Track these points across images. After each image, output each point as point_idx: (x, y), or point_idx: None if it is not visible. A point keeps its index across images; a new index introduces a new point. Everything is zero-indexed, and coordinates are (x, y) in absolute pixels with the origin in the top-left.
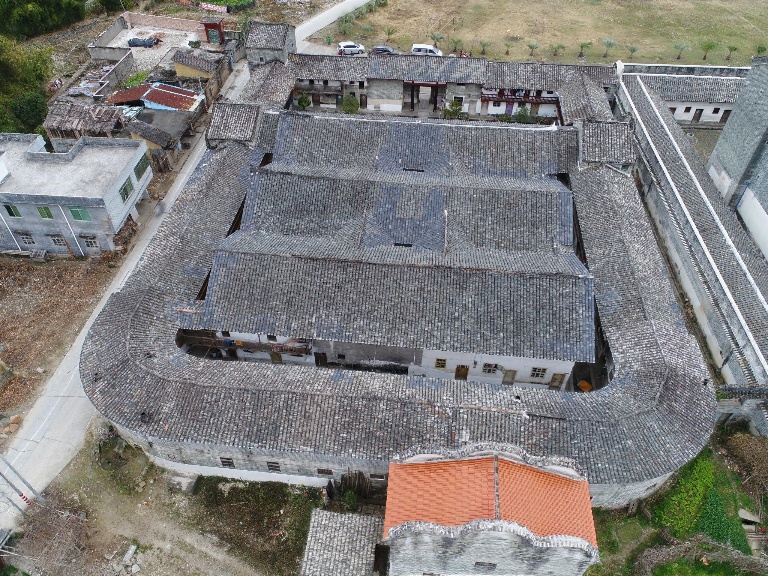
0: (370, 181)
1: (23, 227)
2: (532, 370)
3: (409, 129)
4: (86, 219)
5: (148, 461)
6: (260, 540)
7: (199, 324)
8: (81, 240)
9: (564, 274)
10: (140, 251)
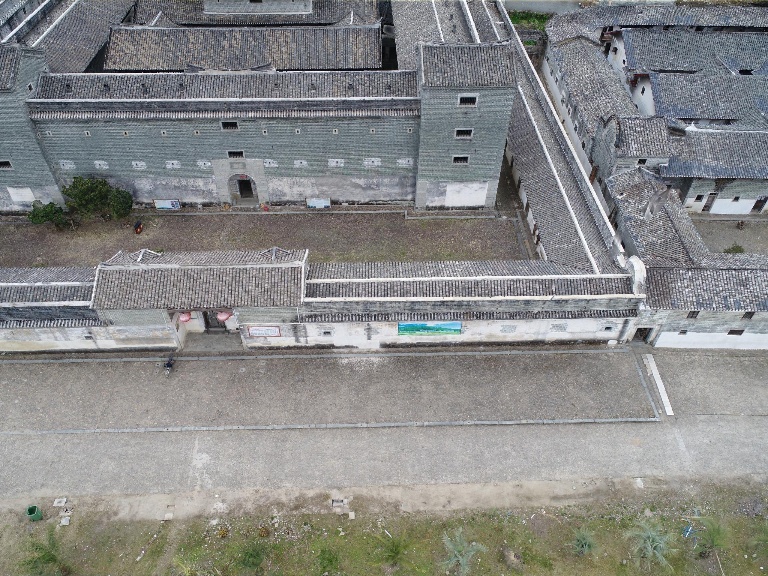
0: None
1: None
2: None
3: None
4: None
5: None
6: None
7: None
8: None
9: (640, 28)
10: None
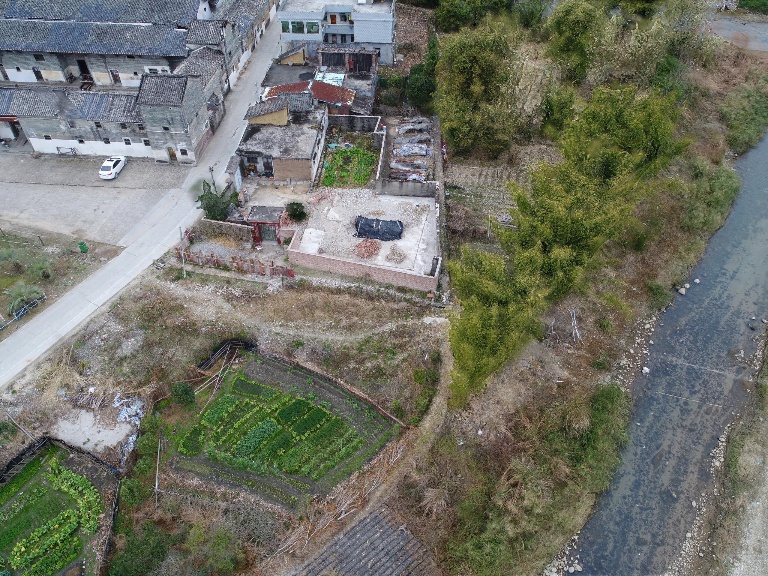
0: None
1: None
2: None
3: None
4: None
5: None
6: None
7: None
8: None
9: None
10: None
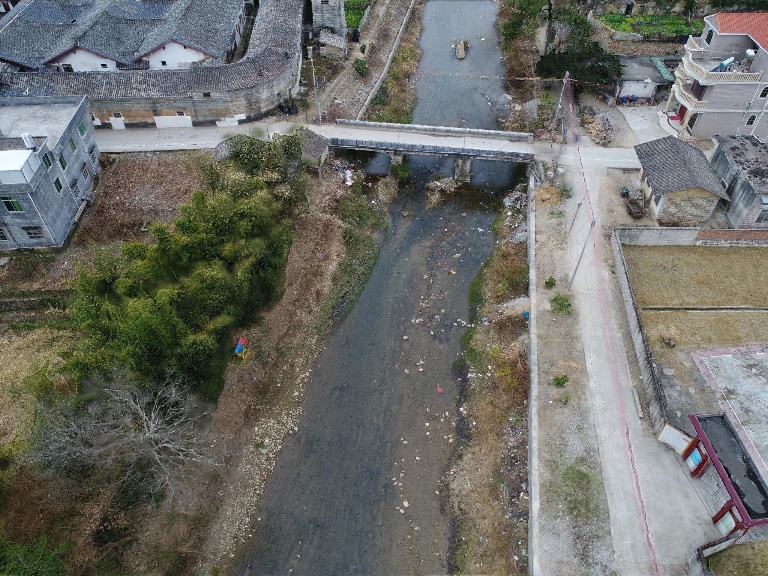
0: (104, 12)
1: (71, 177)
2: (242, 11)
3: (31, 11)
4: (84, 132)
5: (293, 98)
6: (327, 74)
7: (219, 60)
8: (90, 159)
9: None
10: (101, 148)
